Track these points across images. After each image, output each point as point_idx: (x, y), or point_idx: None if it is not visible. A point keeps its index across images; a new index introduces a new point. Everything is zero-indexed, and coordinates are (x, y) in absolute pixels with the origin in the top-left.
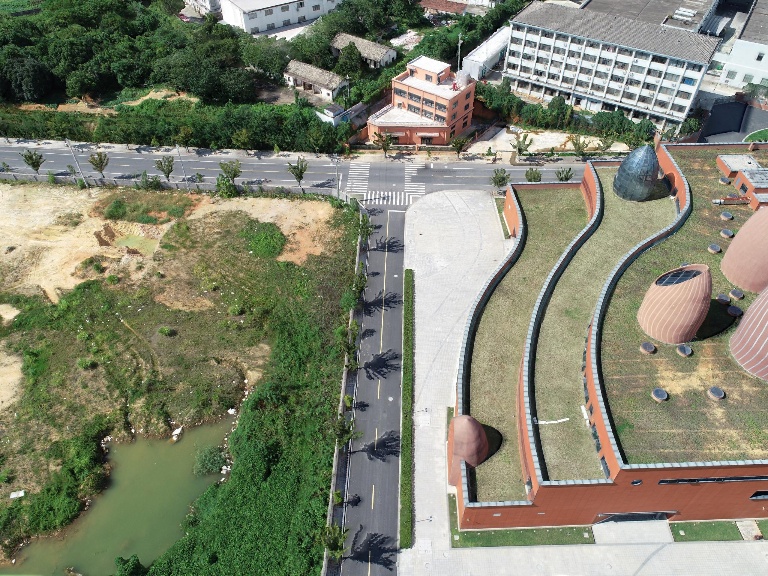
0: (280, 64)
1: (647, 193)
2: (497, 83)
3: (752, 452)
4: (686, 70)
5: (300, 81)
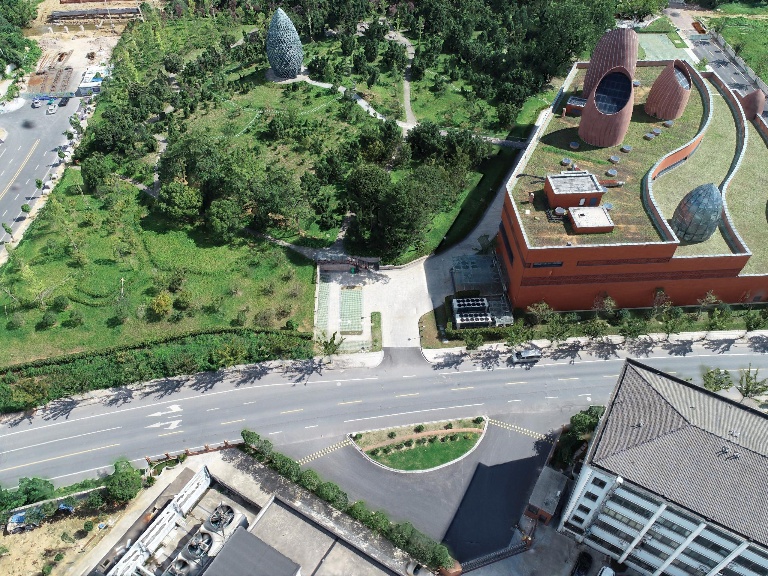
0: None
1: None
2: None
3: None
4: None
5: None
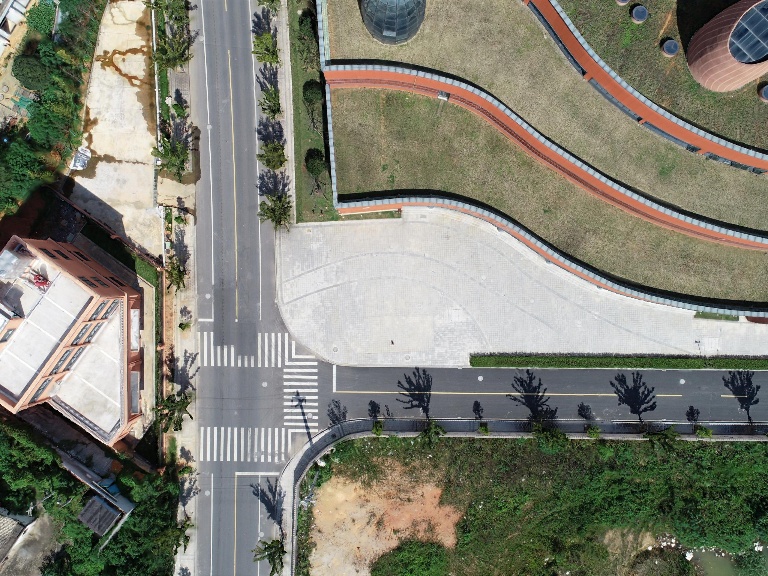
0: None
1: None
2: None
3: None
4: None
5: None
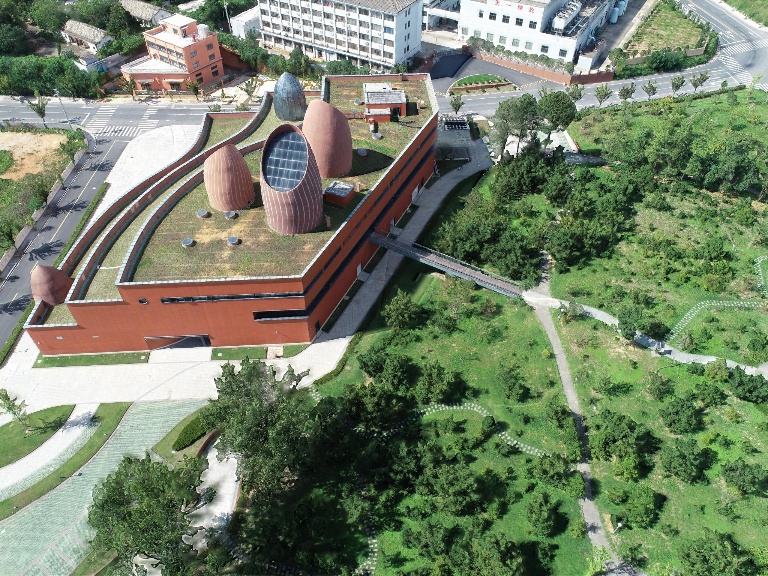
0: (56, 23)
1: (295, 113)
2: (262, 41)
3: (232, 277)
4: (384, 20)
5: (74, 37)
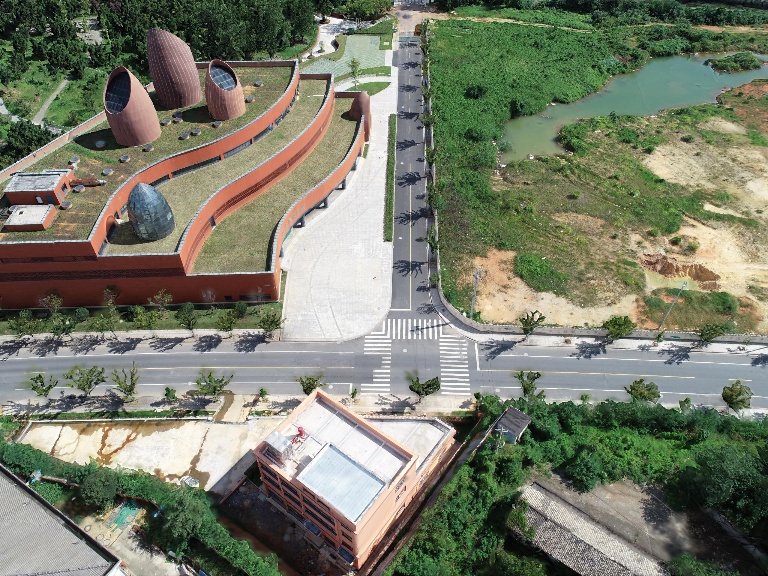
0: None
1: None
2: None
3: None
4: None
5: None
